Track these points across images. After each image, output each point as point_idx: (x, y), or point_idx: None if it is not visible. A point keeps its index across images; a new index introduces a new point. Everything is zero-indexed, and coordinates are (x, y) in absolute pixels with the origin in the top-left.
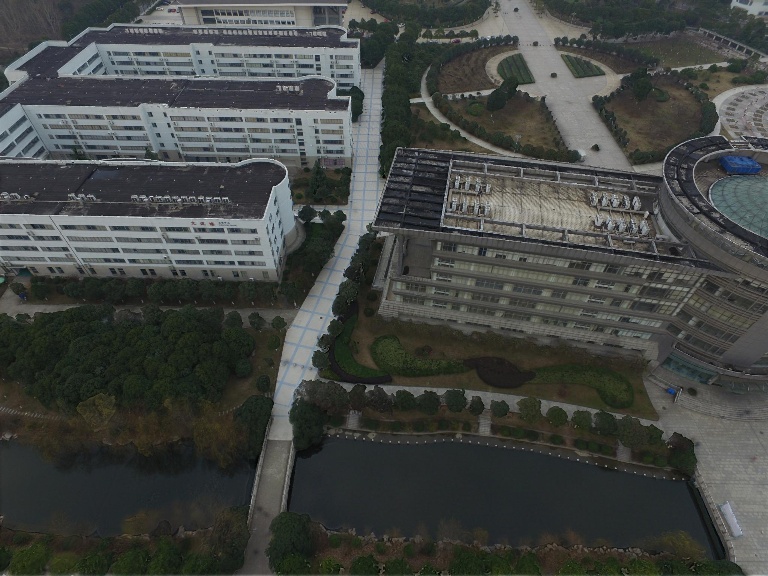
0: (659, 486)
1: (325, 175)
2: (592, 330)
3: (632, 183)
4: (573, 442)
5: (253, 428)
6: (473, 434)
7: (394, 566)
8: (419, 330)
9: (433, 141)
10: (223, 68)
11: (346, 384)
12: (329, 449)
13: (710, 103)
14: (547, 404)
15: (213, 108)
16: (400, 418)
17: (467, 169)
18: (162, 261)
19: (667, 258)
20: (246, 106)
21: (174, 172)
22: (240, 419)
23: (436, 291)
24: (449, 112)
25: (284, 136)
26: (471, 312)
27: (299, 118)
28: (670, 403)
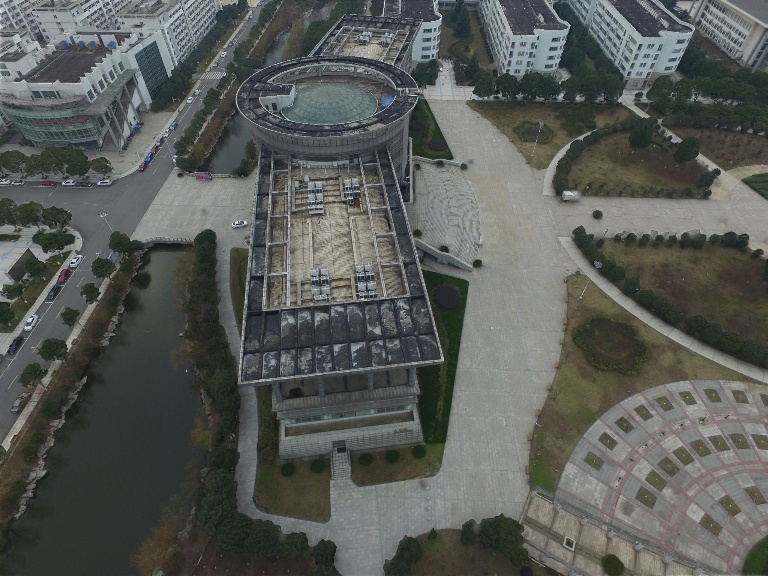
0: None
1: (473, 65)
2: None
3: None
4: None
5: None
6: None
7: (222, 82)
8: None
9: (563, 120)
10: None
11: None
12: None
13: None
14: None
15: None
16: None
17: None
18: None
19: None
20: (511, 12)
21: (428, 3)
22: None
23: None
24: None
25: None
26: None
27: None
28: None
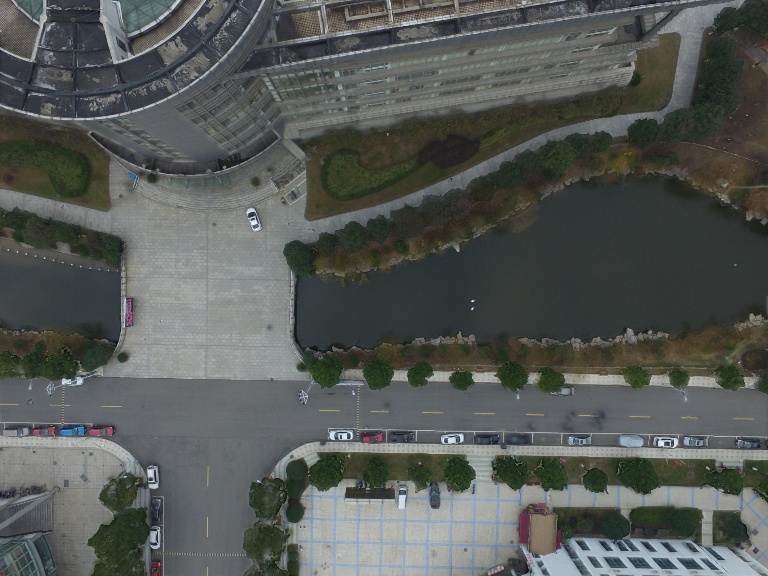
0: (93, 277)
1: None
2: None
3: None
4: (12, 235)
5: None
6: None
7: None
8: None
9: None
10: None
11: None
12: None
13: None
14: None
15: None
16: None
17: None
18: None
19: None
20: None
21: None
22: None
23: None
24: None
25: None
26: None
27: None
28: (129, 190)
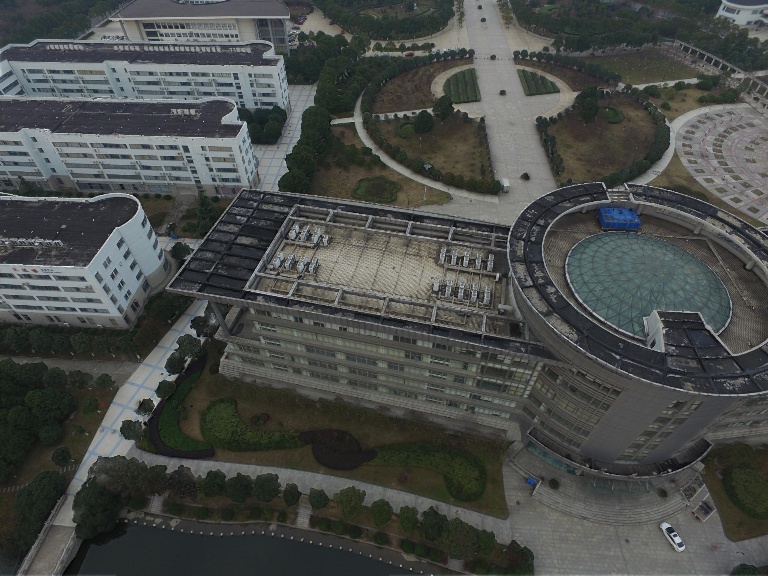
0: None
1: (211, 207)
2: (446, 404)
3: (491, 237)
4: (400, 543)
5: (27, 514)
6: (289, 526)
7: None
8: (258, 395)
9: (350, 167)
10: (140, 86)
11: (162, 457)
12: (133, 533)
13: (664, 126)
14: (382, 492)
15: (95, 134)
16: (209, 503)
17: (315, 215)
18: (1, 305)
19: (495, 338)
20: (133, 131)
21: (23, 208)
22: (15, 503)
23: (270, 354)
24: (374, 134)
25: (174, 163)
26: (314, 377)
27: (186, 145)
28: (527, 497)
